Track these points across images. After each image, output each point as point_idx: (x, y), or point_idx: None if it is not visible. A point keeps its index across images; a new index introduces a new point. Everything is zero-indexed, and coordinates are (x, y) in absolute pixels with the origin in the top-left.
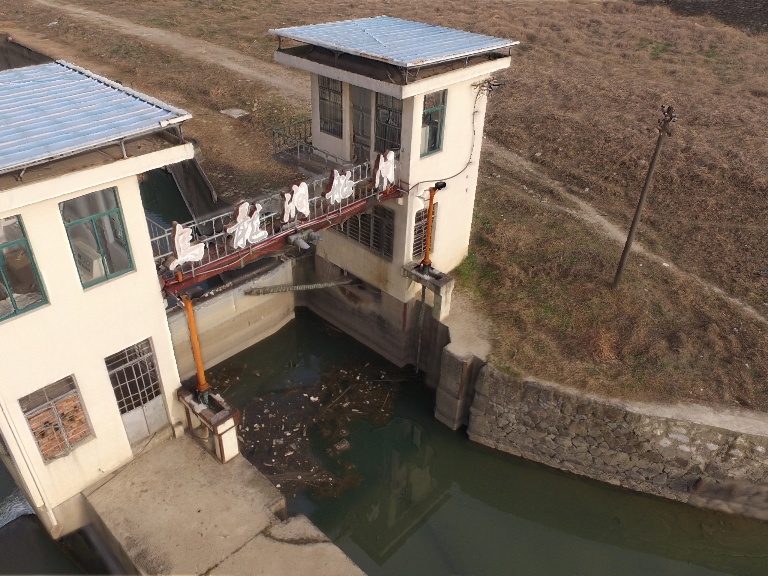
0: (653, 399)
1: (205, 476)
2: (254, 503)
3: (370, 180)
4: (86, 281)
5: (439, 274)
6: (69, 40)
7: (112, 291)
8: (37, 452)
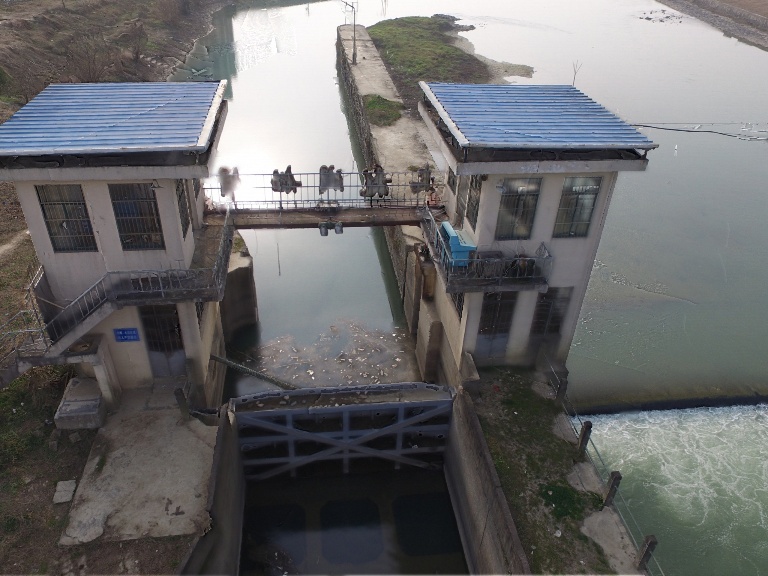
0: None
1: None
2: None
3: (207, 227)
4: None
5: None
6: None
7: None
8: None
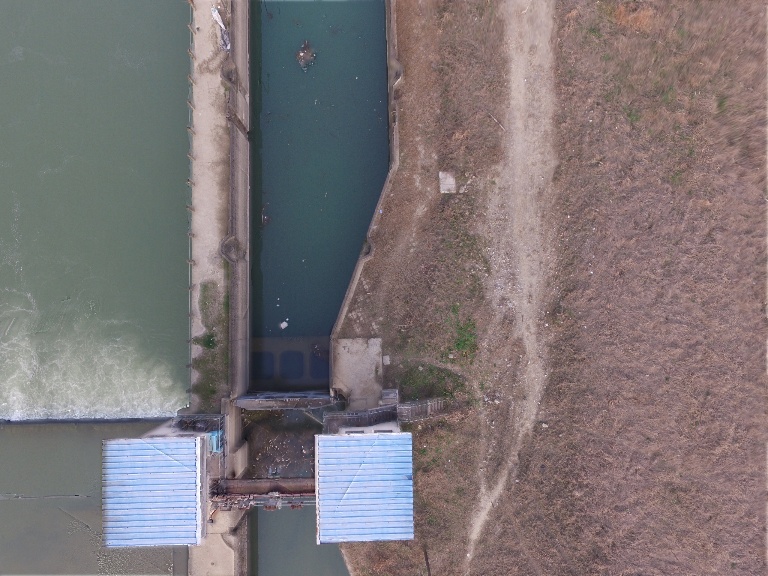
0: None
1: None
2: (226, 523)
3: None
4: None
5: None
6: None
7: None
8: None
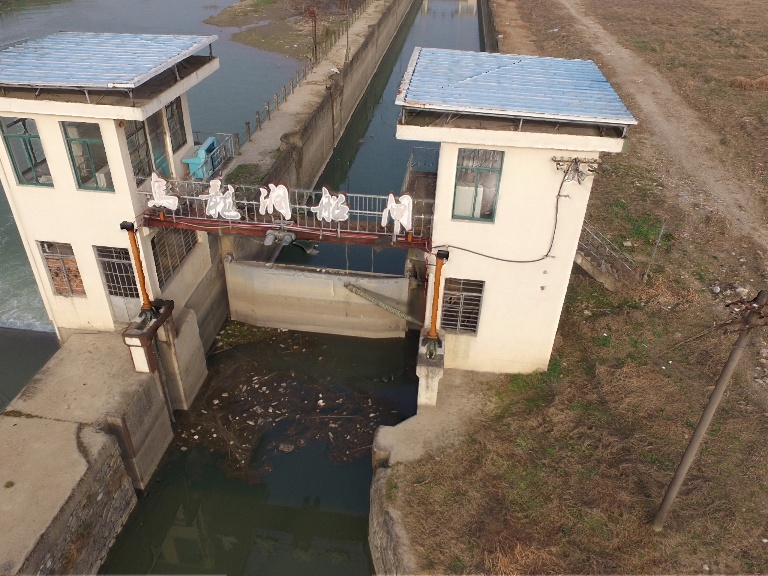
0: None
1: (118, 369)
2: (106, 405)
3: (427, 224)
4: (91, 185)
5: (438, 355)
6: (547, 46)
7: (97, 199)
8: (49, 282)
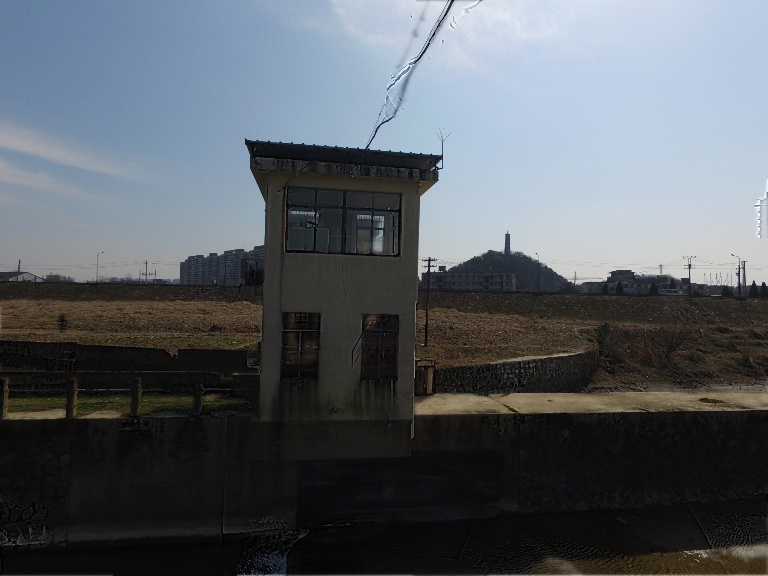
0: None
1: (437, 398)
2: None
3: None
4: None
5: None
6: None
7: None
8: None
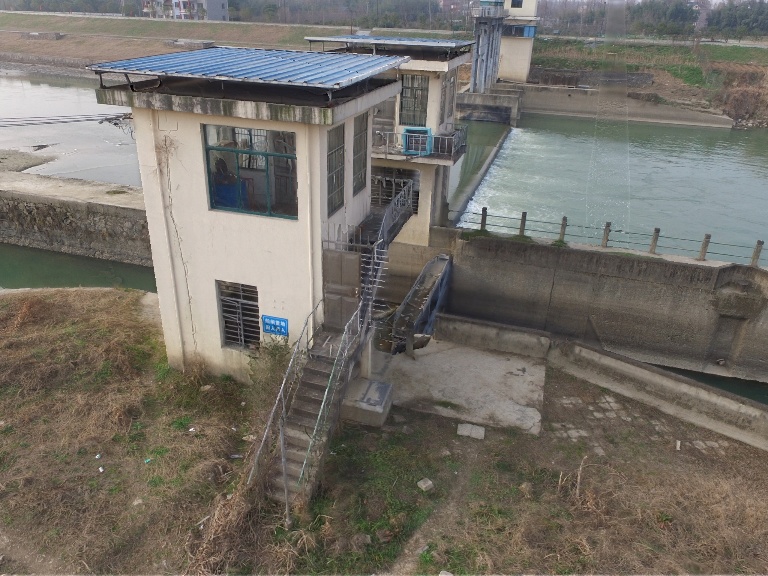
0: (1, 296)
1: None
2: None
3: None
4: None
5: None
6: None
7: None
8: None
